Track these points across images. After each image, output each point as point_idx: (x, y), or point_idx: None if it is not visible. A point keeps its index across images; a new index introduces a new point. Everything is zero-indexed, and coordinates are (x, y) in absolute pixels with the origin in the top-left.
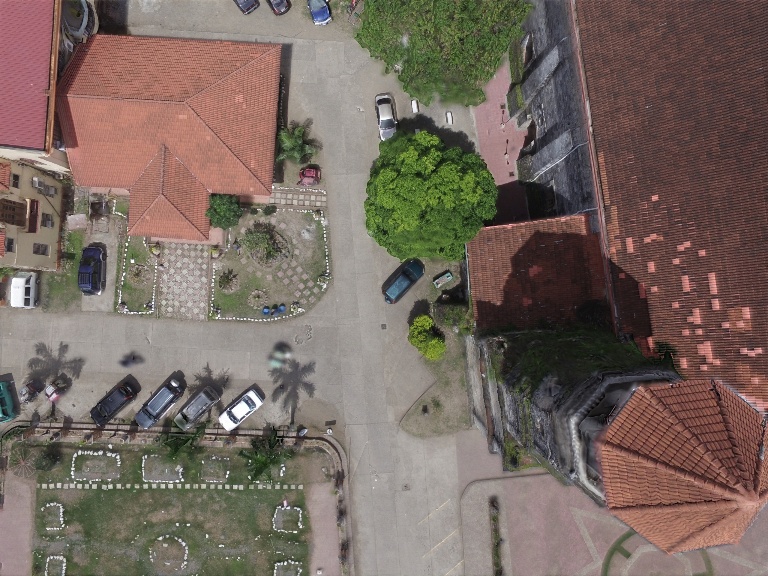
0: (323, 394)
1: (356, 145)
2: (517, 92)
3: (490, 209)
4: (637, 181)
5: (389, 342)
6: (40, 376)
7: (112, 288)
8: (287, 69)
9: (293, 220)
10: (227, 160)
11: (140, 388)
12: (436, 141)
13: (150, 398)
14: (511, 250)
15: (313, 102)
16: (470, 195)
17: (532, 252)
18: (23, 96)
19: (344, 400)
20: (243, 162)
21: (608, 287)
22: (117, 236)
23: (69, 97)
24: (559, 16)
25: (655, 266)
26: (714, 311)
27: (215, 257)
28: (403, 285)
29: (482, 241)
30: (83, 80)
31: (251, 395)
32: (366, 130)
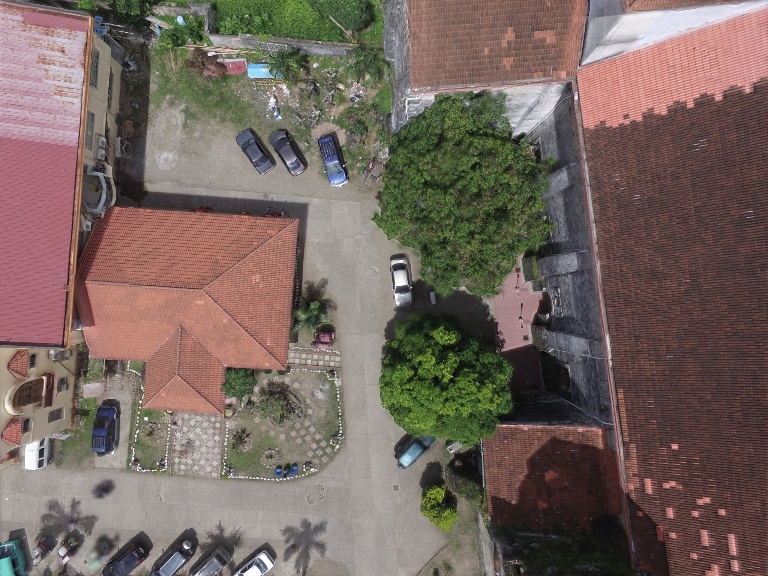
0: (334, 554)
1: (370, 305)
2: (533, 264)
3: (506, 406)
4: (657, 426)
5: (401, 503)
6: (52, 532)
7: (125, 445)
8: (303, 228)
9: (307, 380)
10: (243, 340)
11: (152, 545)
12: (453, 340)
13: (162, 556)
14: (527, 452)
15: (328, 262)
16: (487, 405)
17: (548, 457)
18: (42, 293)
19: (355, 560)
20: (259, 341)
21: (625, 519)
22: (131, 393)
23: (87, 284)
24: (578, 225)
25: (674, 513)
26: (733, 572)
27: (228, 416)
28: (416, 453)
29: (498, 438)
30: (101, 263)
31: (263, 558)
32: (381, 290)
